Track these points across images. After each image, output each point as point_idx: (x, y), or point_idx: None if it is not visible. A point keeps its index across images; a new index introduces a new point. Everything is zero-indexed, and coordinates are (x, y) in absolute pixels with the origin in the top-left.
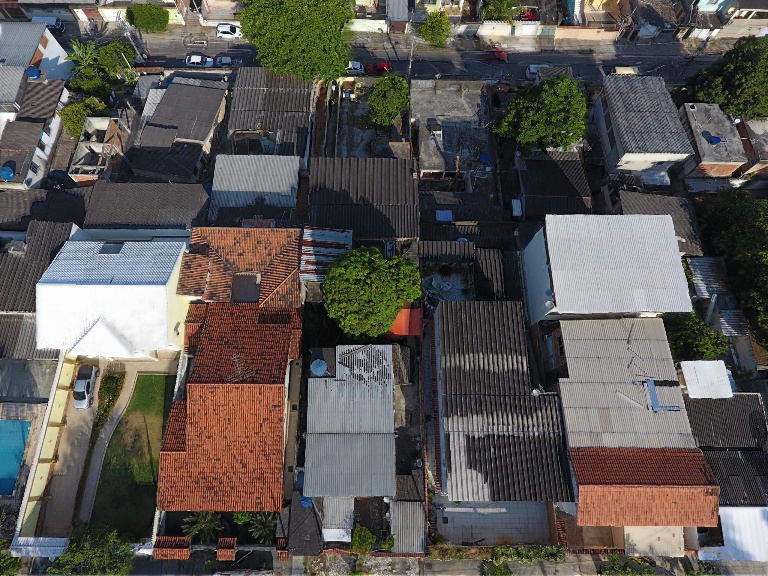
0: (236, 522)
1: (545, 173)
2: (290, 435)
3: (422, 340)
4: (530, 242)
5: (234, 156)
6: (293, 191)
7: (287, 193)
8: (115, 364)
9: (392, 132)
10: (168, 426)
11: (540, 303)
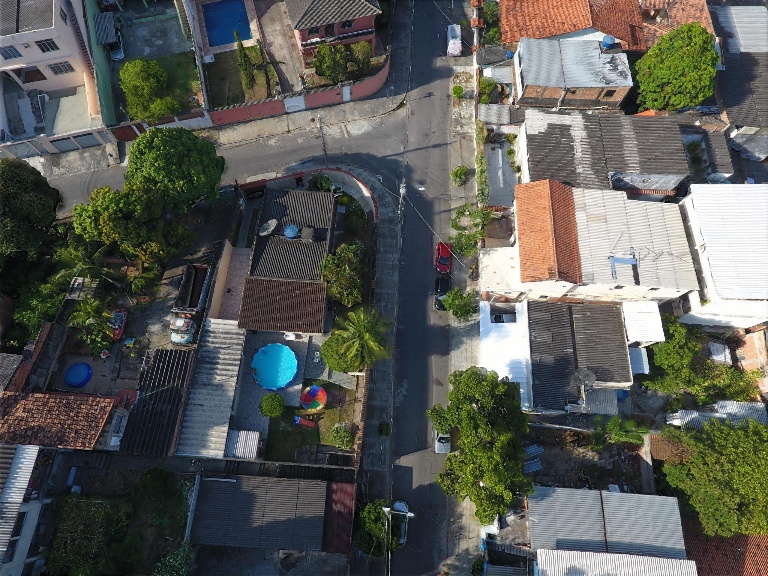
0: None
1: None
2: None
3: None
4: None
5: None
6: None
7: (743, 50)
8: None
9: None
10: None
11: None
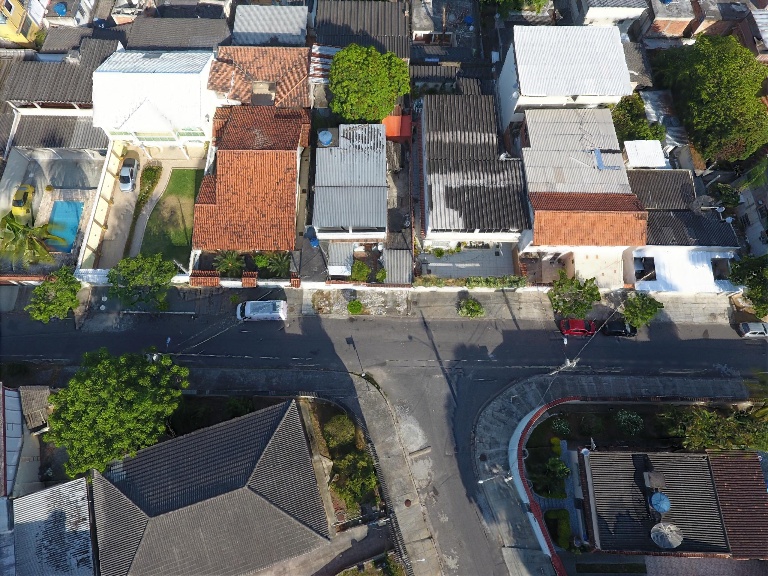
0: (256, 269)
1: None
2: (300, 210)
3: (411, 139)
4: (503, 65)
5: (252, 6)
6: (303, 32)
7: (297, 33)
8: (153, 162)
9: None
10: (201, 190)
11: (510, 105)
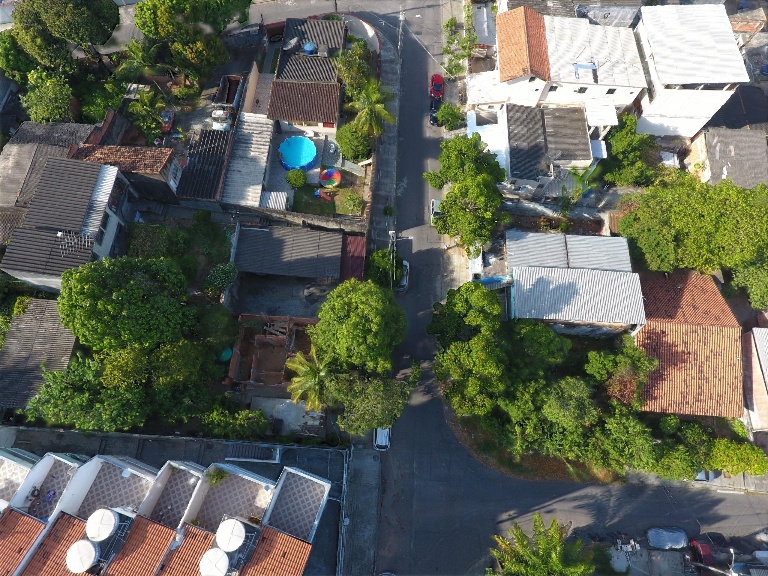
0: None
1: (766, 107)
2: None
3: None
4: None
5: None
6: None
7: None
8: None
9: None
10: None
11: None
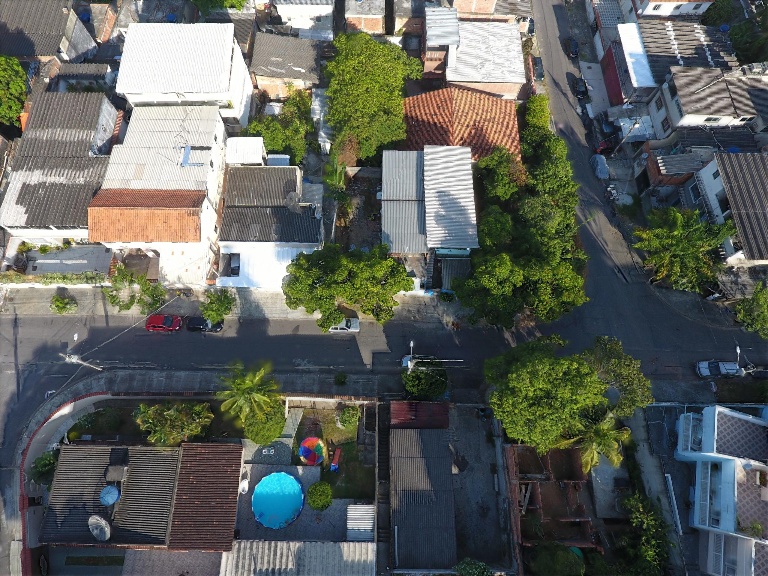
0: None
1: None
2: None
3: None
4: None
5: None
6: None
7: None
8: None
9: (112, 4)
10: None
11: None
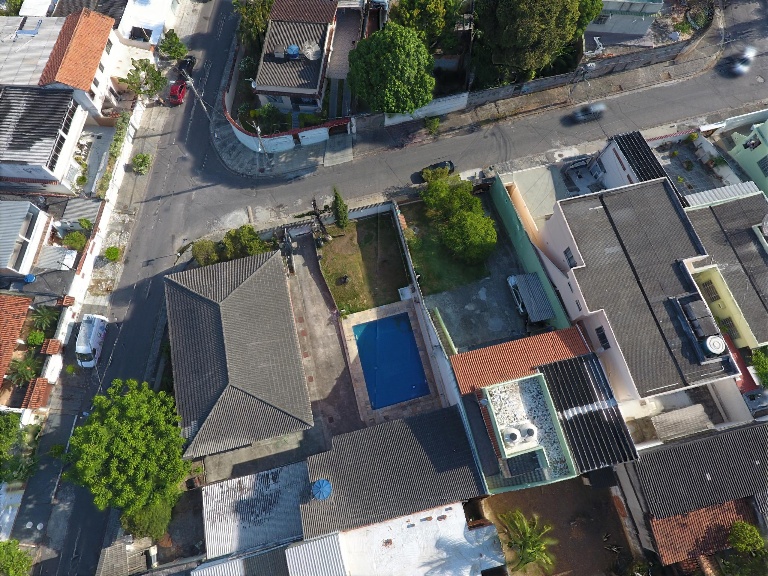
0: None
1: None
2: None
3: None
4: None
5: None
6: None
7: None
8: None
9: None
10: None
11: None
